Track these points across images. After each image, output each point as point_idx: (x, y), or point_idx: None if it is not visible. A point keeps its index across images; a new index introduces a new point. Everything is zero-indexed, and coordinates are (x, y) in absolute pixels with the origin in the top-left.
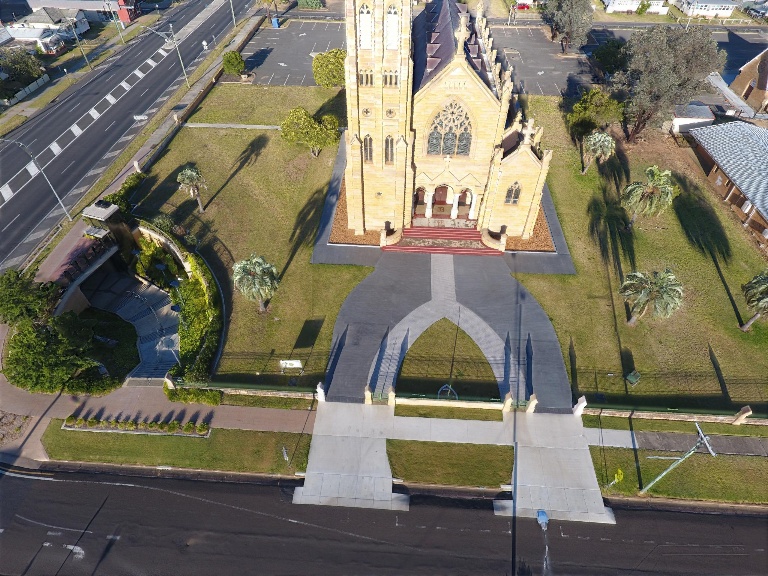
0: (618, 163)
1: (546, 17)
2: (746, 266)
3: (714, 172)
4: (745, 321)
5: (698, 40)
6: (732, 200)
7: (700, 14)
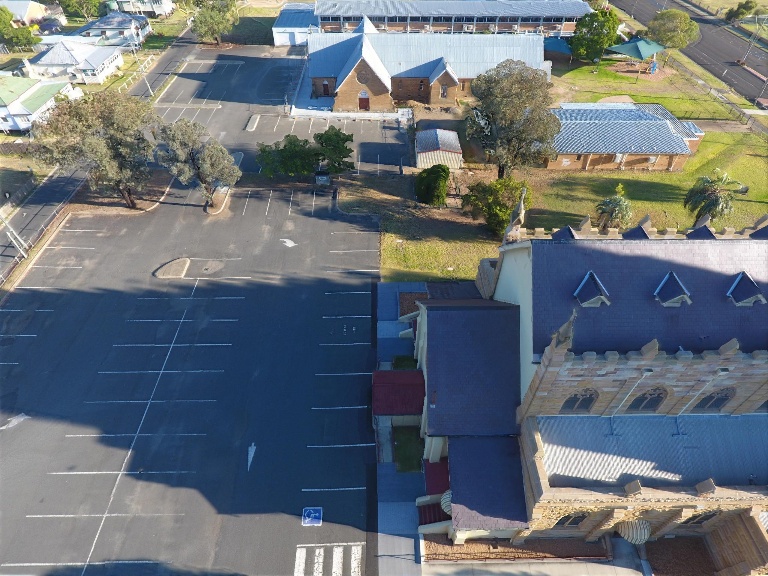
0: (553, 217)
1: (17, 200)
2: (689, 183)
3: (554, 161)
4: (763, 200)
5: (537, 73)
6: (594, 164)
7: (108, 75)
